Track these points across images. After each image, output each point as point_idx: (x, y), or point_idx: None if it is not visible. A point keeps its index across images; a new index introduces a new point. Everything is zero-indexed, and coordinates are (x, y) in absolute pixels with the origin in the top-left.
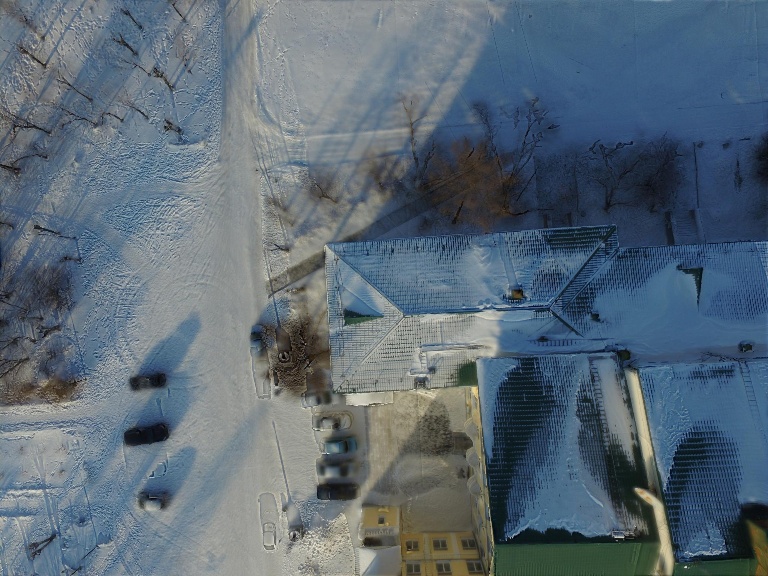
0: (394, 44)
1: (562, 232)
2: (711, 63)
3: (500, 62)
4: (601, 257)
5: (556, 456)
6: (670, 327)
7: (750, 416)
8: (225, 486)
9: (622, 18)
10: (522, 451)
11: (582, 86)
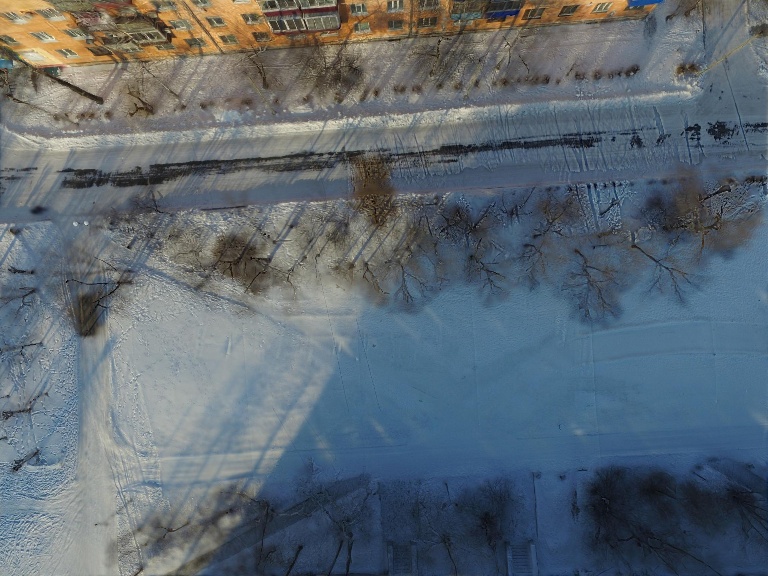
0: (242, 371)
1: None
2: (550, 394)
3: (345, 391)
4: None
5: None
6: None
7: None
8: None
9: (462, 350)
10: None
11: (424, 415)
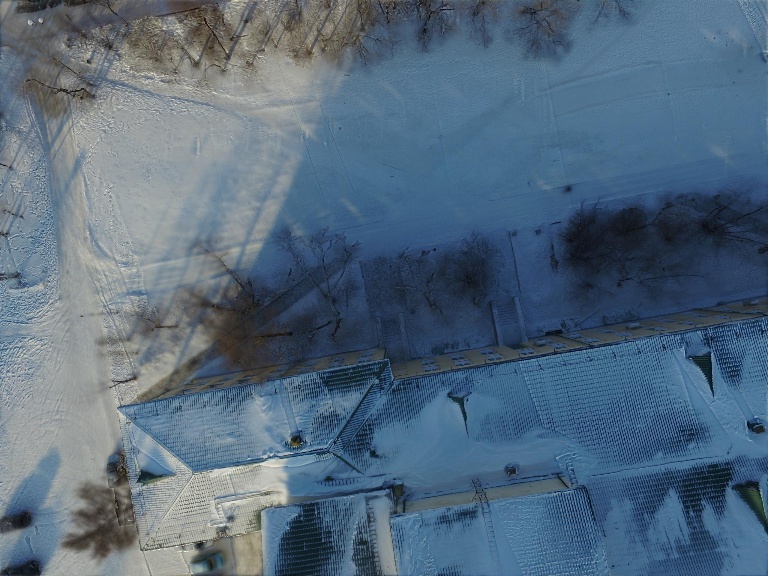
0: (214, 169)
1: (338, 372)
2: (516, 154)
3: (316, 175)
4: (376, 393)
5: None
6: (442, 456)
7: (490, 558)
8: None
9: (426, 121)
10: None
11: (397, 189)
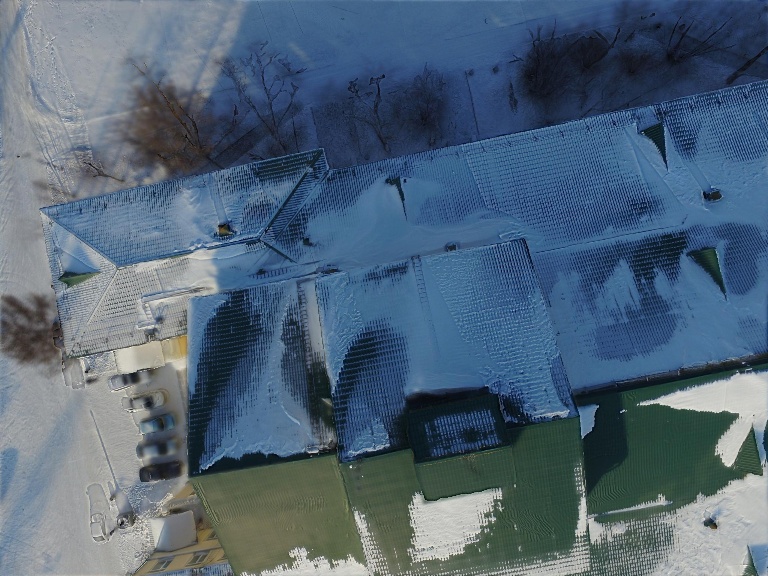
0: (158, 17)
1: (270, 163)
2: None
3: (264, 19)
4: (310, 182)
5: (258, 382)
6: (379, 240)
7: (420, 308)
8: (51, 483)
9: None
10: (225, 382)
11: (348, 32)
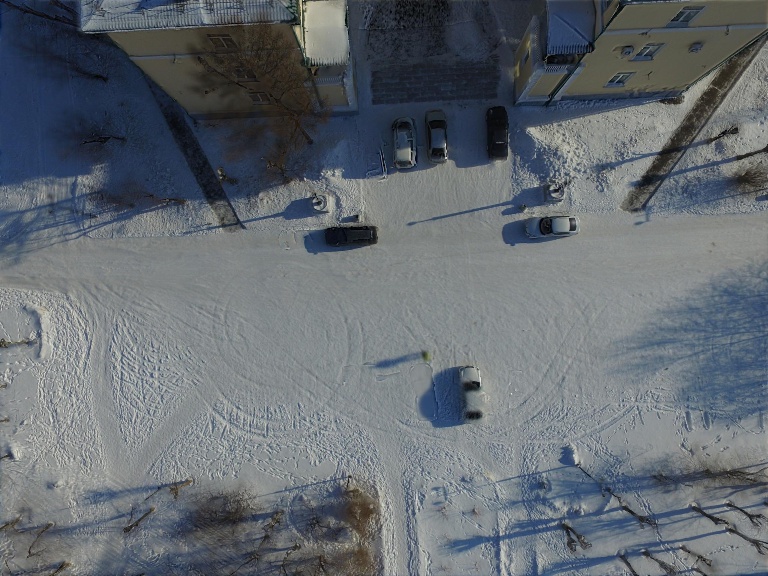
0: None
1: None
2: None
3: None
4: None
5: None
6: None
7: None
8: (494, 289)
9: None
10: None
11: None
